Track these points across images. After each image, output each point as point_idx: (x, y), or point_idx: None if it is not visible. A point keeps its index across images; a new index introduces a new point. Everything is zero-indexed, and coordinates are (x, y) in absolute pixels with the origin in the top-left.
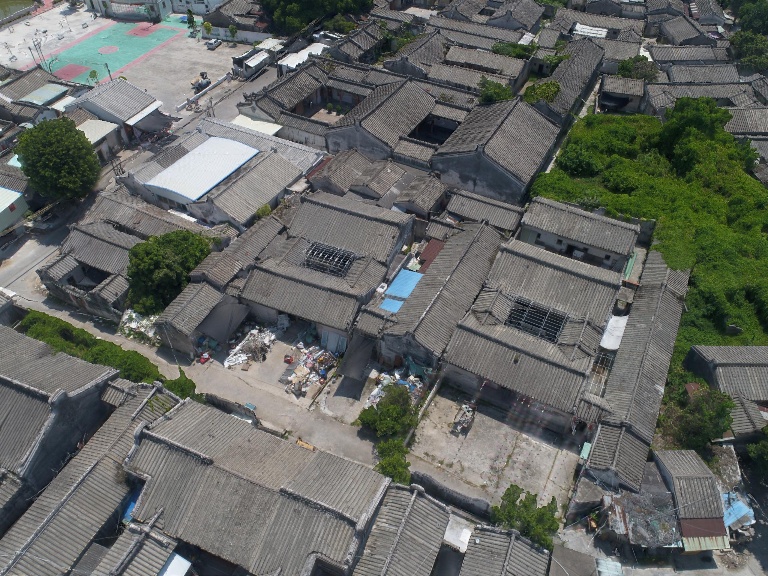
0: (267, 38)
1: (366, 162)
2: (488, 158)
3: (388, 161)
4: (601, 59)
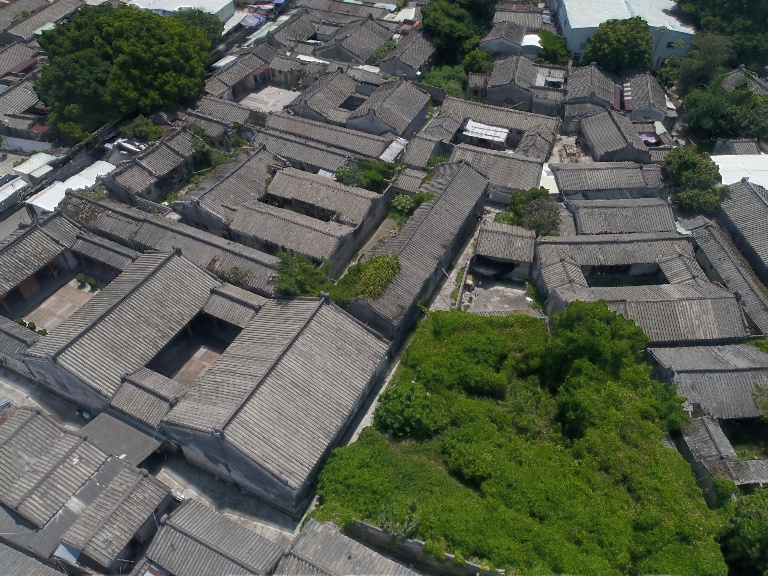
0: (36, 153)
1: (53, 432)
2: (232, 447)
3: (79, 440)
4: (484, 191)
